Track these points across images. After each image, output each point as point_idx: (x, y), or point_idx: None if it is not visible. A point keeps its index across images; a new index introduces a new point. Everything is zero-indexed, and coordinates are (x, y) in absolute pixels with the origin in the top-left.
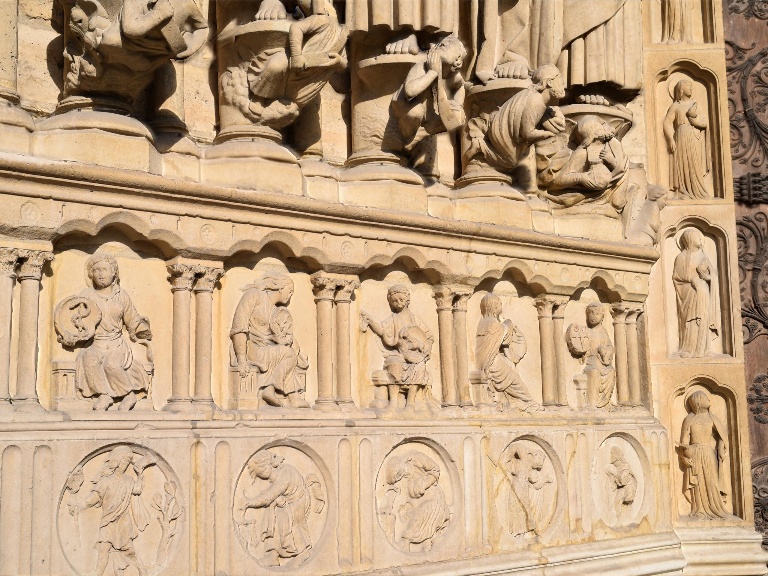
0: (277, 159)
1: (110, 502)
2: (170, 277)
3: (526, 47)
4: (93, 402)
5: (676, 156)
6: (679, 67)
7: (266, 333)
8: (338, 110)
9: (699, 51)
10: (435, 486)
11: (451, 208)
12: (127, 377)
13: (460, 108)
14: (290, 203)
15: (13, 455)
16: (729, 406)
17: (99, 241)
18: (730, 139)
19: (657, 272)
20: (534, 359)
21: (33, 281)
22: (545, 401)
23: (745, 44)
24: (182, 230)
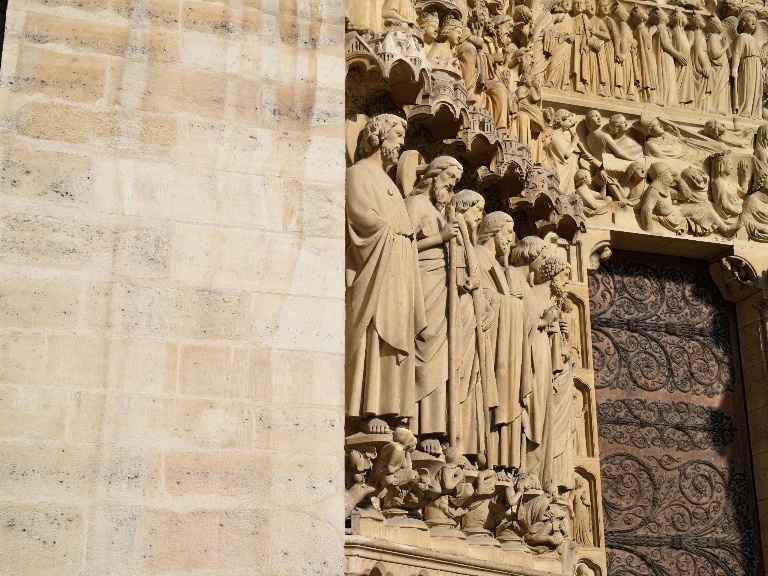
0: (462, 538)
1: None
2: None
3: None
4: None
5: (575, 521)
6: (576, 469)
7: None
8: None
9: (587, 462)
10: None
11: None
12: None
13: None
14: (471, 562)
15: None
16: None
17: None
18: None
19: None
20: None
21: None
22: None
23: None
24: None
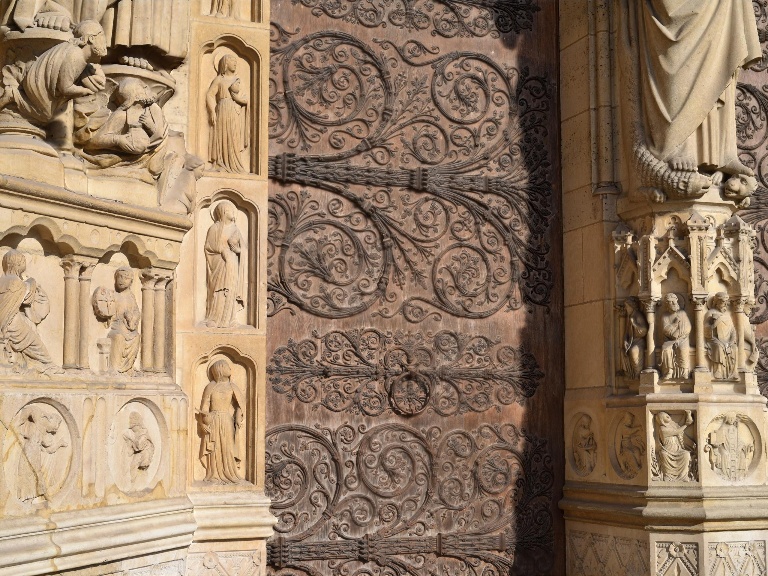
0: None
1: None
2: None
3: None
4: None
5: (216, 129)
6: (225, 41)
7: None
8: None
9: (245, 28)
10: None
11: None
12: None
13: None
14: None
15: None
16: (249, 375)
17: None
18: (269, 118)
19: (189, 241)
20: (57, 320)
21: None
22: (65, 364)
23: (290, 28)
24: None
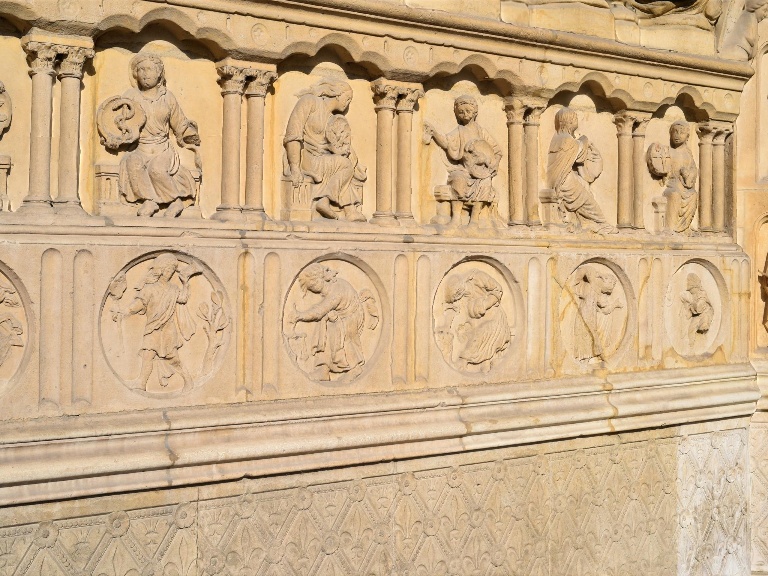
0: None
1: (154, 310)
2: (220, 80)
3: None
4: (138, 208)
5: None
6: None
7: (321, 142)
8: None
9: None
10: (497, 307)
11: (527, 14)
12: (173, 183)
13: None
14: (349, 3)
15: (53, 258)
16: None
17: (144, 39)
18: None
19: (751, 90)
20: (610, 179)
21: (73, 79)
22: (620, 223)
23: None
24: (232, 29)
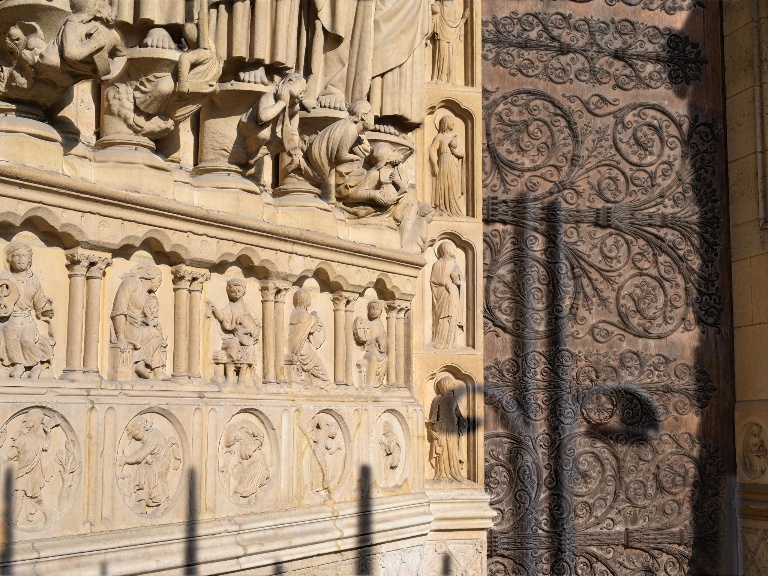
0: (156, 167)
1: (26, 456)
2: (69, 264)
3: (344, 83)
4: (10, 370)
5: (439, 179)
6: (445, 104)
7: (140, 316)
8: (188, 123)
9: (462, 92)
10: (260, 450)
11: (275, 214)
12: (37, 350)
13: (297, 133)
14: (168, 206)
15: None
16: (469, 390)
17: (15, 230)
18: None
19: (419, 276)
20: (329, 345)
21: None
22: (336, 381)
23: (491, 87)
24: (85, 225)
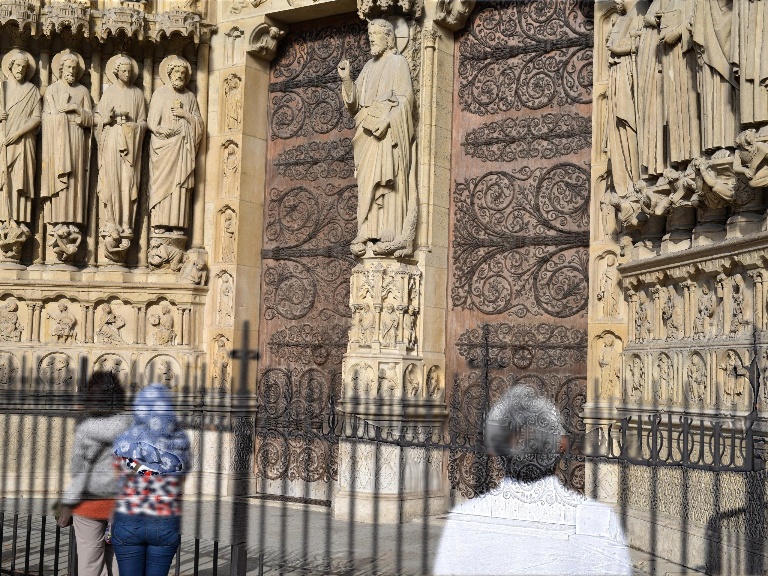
0: (8, 269)
1: None
2: None
3: (112, 220)
4: None
5: None
6: (227, 207)
7: (5, 320)
8: None
9: None
10: (67, 367)
11: (93, 276)
12: None
13: (73, 247)
14: (8, 282)
15: None
16: None
17: None
18: (273, 231)
19: (211, 292)
20: (131, 327)
21: None
22: None
23: (282, 189)
24: None
